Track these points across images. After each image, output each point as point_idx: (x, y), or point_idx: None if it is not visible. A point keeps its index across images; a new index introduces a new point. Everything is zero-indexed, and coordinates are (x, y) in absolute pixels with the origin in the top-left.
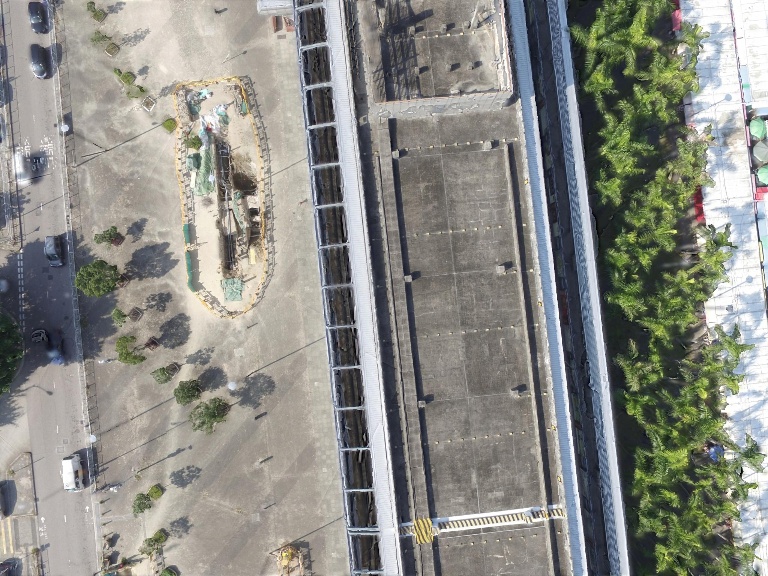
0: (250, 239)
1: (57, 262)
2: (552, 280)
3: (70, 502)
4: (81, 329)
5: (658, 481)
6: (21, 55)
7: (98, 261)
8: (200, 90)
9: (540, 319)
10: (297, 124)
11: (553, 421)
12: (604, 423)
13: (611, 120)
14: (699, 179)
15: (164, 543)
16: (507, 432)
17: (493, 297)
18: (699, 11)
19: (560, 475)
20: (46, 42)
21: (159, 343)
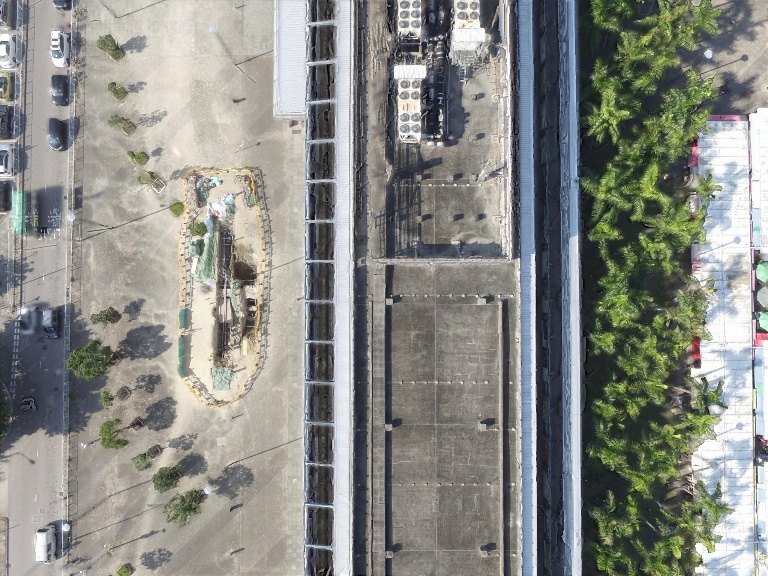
0: (244, 329)
1: (53, 334)
2: (533, 441)
3: (41, 571)
4: (69, 402)
5: None
6: (39, 125)
7: (92, 343)
8: (210, 177)
9: (517, 479)
10: (302, 220)
11: None
12: None
13: (613, 268)
14: (697, 331)
15: None
16: None
17: (472, 452)
18: (716, 150)
19: None
20: (65, 114)
21: (144, 424)
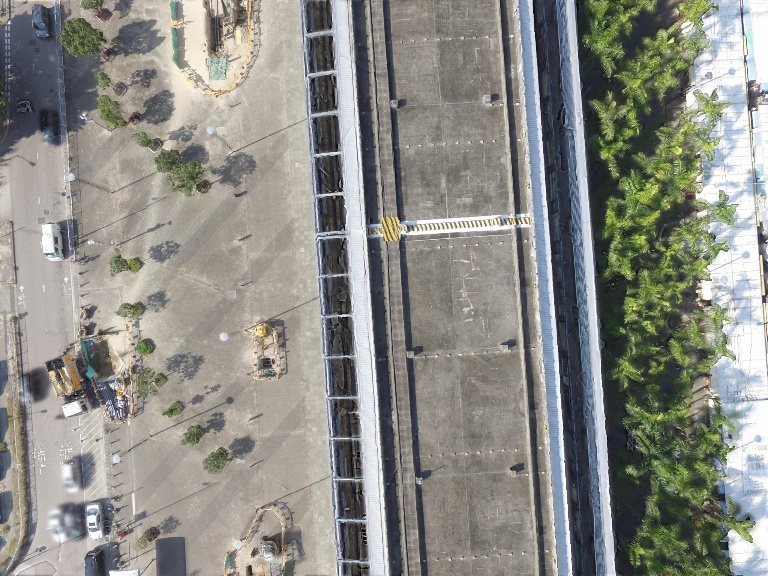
0: (237, 22)
1: (44, 32)
2: None
3: (49, 272)
4: (66, 101)
5: (629, 223)
6: None
7: None
8: None
9: (515, 30)
10: None
11: (524, 127)
12: (577, 159)
13: None
14: None
15: (141, 316)
16: (478, 140)
17: (469, 7)
18: None
19: (529, 180)
20: None
21: (142, 118)
